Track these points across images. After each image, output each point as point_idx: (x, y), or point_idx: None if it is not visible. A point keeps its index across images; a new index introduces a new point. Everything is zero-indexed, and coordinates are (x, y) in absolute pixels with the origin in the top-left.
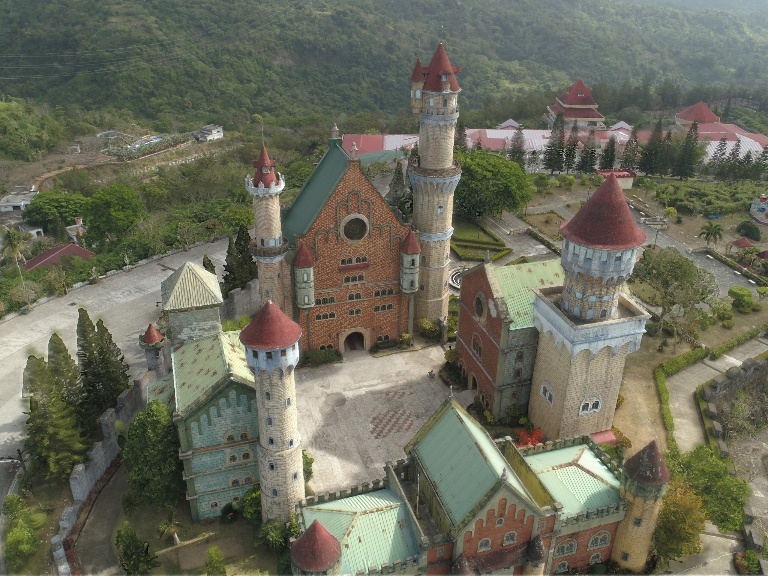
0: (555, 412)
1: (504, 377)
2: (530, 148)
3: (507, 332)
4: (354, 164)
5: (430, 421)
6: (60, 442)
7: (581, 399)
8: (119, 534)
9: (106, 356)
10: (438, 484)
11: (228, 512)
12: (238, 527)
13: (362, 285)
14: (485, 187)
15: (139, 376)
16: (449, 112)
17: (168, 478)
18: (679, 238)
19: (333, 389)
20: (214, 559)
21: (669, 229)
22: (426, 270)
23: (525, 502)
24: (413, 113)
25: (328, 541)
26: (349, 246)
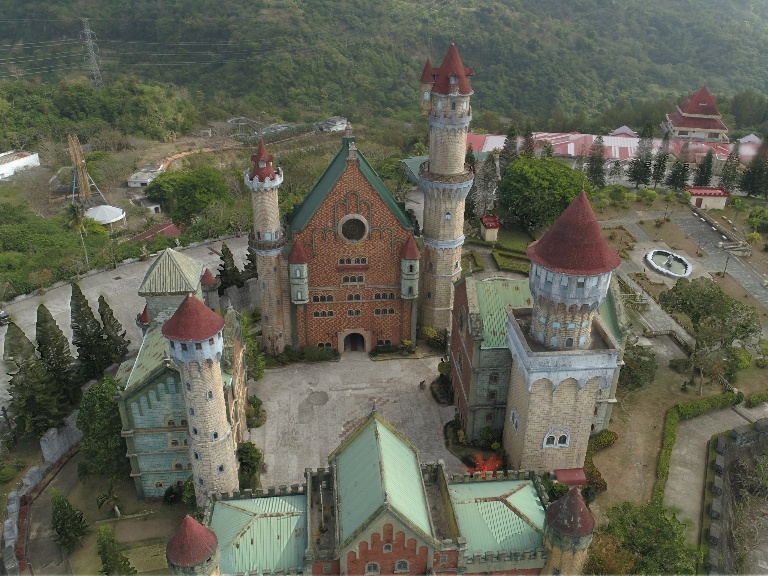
0: (519, 441)
1: (477, 397)
2: (612, 158)
3: (478, 350)
4: (352, 164)
5: (353, 433)
6: (38, 405)
7: (545, 431)
8: None
9: (99, 330)
10: (341, 498)
11: (170, 494)
12: (178, 510)
13: (362, 286)
14: (540, 196)
15: (131, 352)
16: (458, 116)
17: (115, 453)
18: (760, 268)
19: (319, 387)
20: (103, 537)
21: (752, 257)
22: (433, 277)
23: (414, 531)
24: None
25: (199, 538)
26: (348, 246)
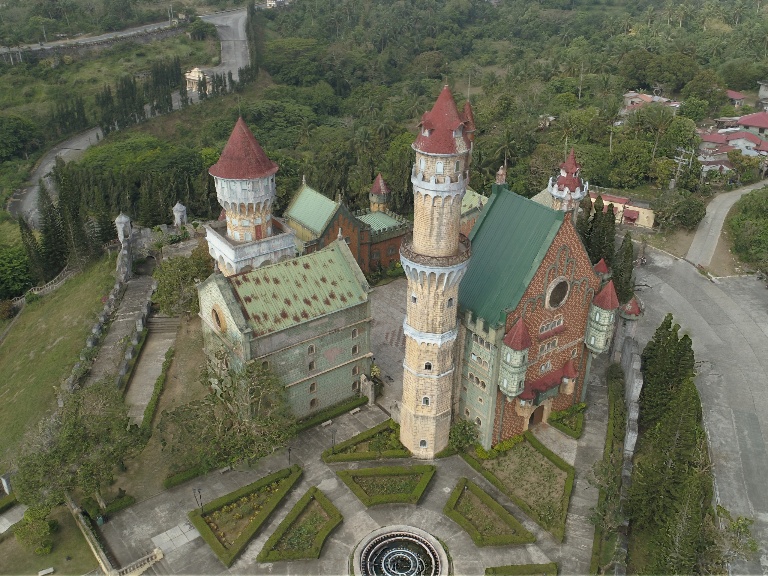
0: None
1: None
2: None
3: None
4: None
5: None
6: None
7: None
8: None
9: None
10: None
11: None
12: None
13: None
14: None
15: None
16: None
17: None
18: None
19: None
20: None
21: None
22: None
23: None
24: None
25: None
26: None
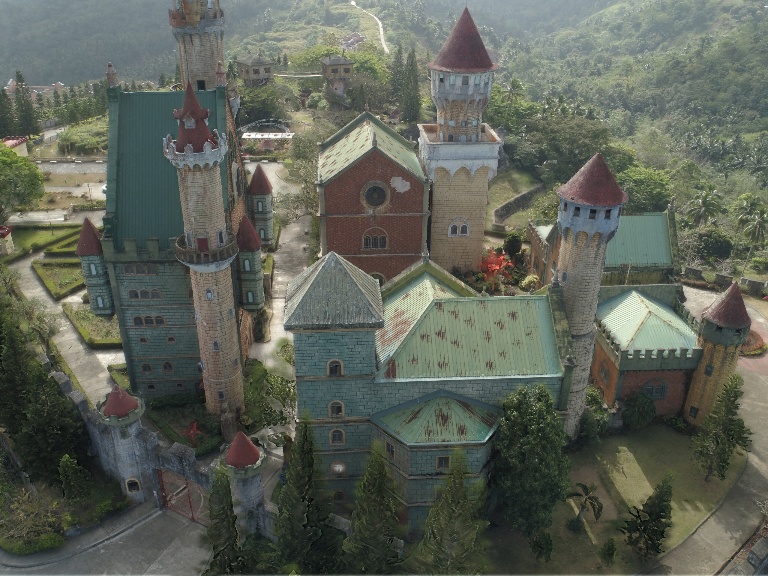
0: (474, 237)
1: None
2: None
3: None
4: None
5: None
6: None
7: None
8: (608, 547)
9: None
10: (627, 262)
11: None
12: None
13: None
14: None
15: None
16: None
17: None
18: None
19: None
20: None
21: None
22: None
23: None
24: (193, 22)
25: None
26: None
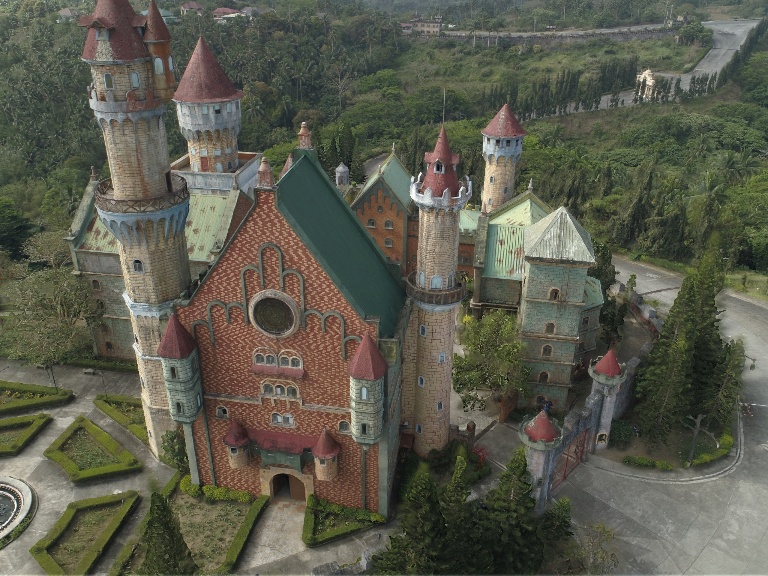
0: None
1: None
2: None
3: None
4: None
5: None
6: None
7: None
8: (615, 301)
9: None
10: None
11: None
12: None
13: None
14: None
15: None
16: None
17: None
18: None
19: None
20: None
21: None
22: None
23: None
24: None
25: None
26: None
